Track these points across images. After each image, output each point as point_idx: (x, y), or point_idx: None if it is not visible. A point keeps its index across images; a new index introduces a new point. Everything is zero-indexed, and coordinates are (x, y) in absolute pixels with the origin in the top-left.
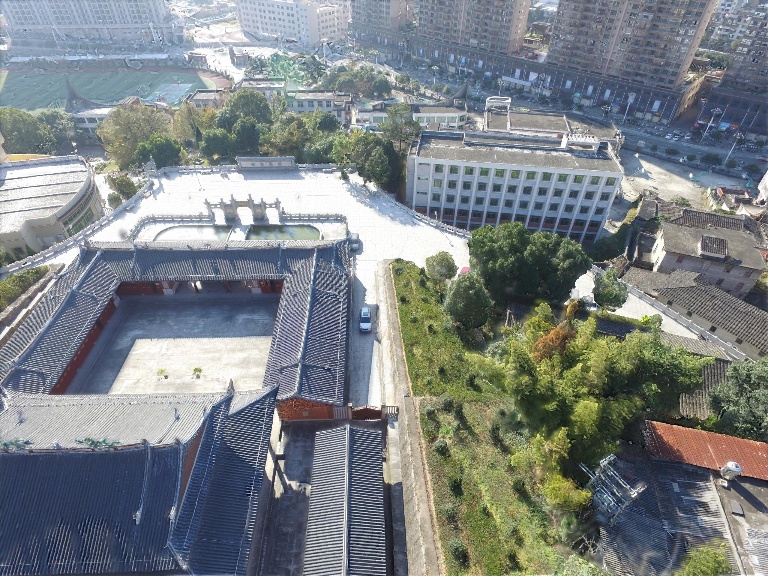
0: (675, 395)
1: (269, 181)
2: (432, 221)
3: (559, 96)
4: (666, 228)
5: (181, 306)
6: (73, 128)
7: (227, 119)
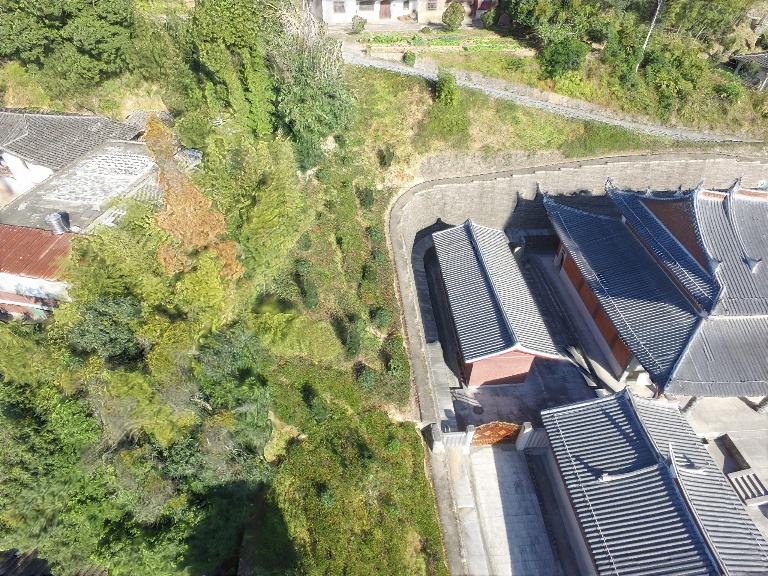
0: None
1: None
2: None
3: None
4: None
5: None
6: None
7: None
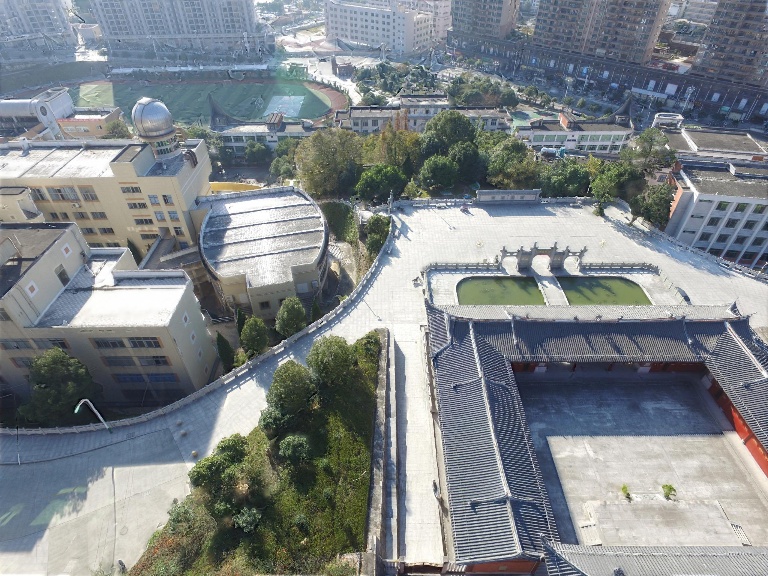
0: None
1: (519, 218)
2: (750, 271)
3: (702, 109)
4: None
5: (564, 389)
6: (222, 147)
7: (436, 144)
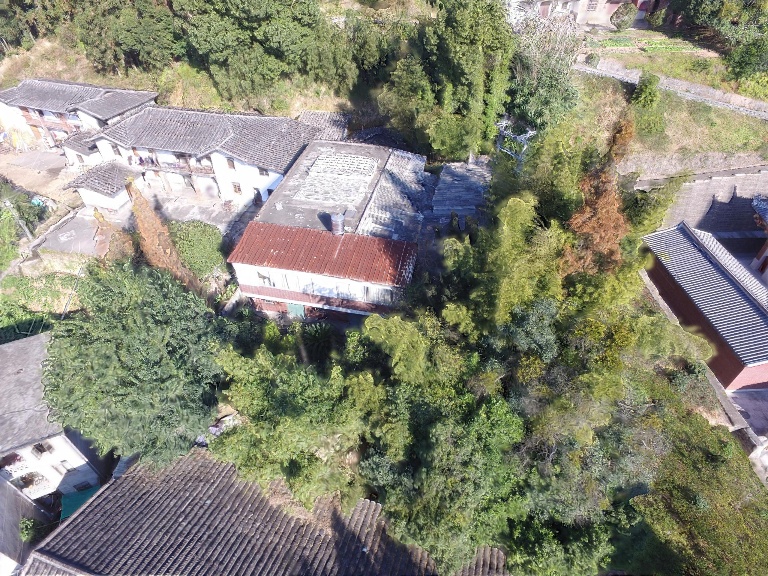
0: None
1: None
2: None
3: None
4: None
5: None
6: None
7: None
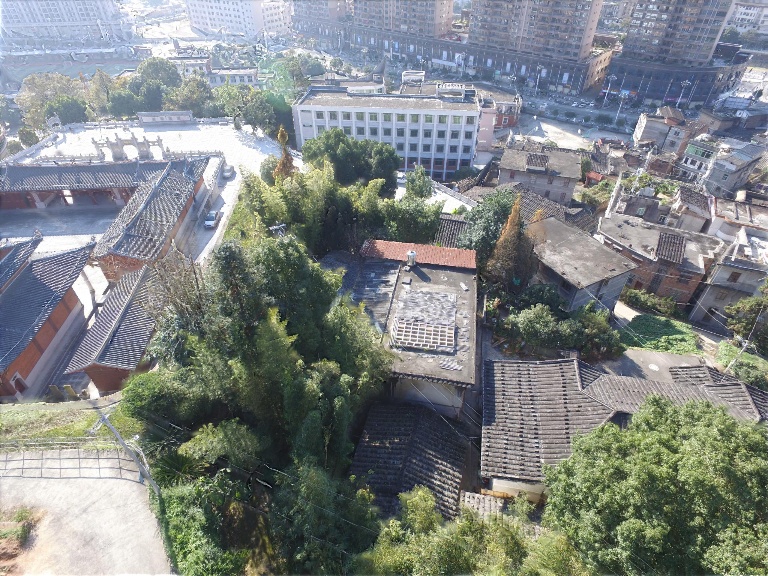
0: (421, 236)
1: (166, 132)
2: None
3: (482, 74)
4: (507, 153)
5: (50, 215)
6: (5, 108)
7: (137, 84)
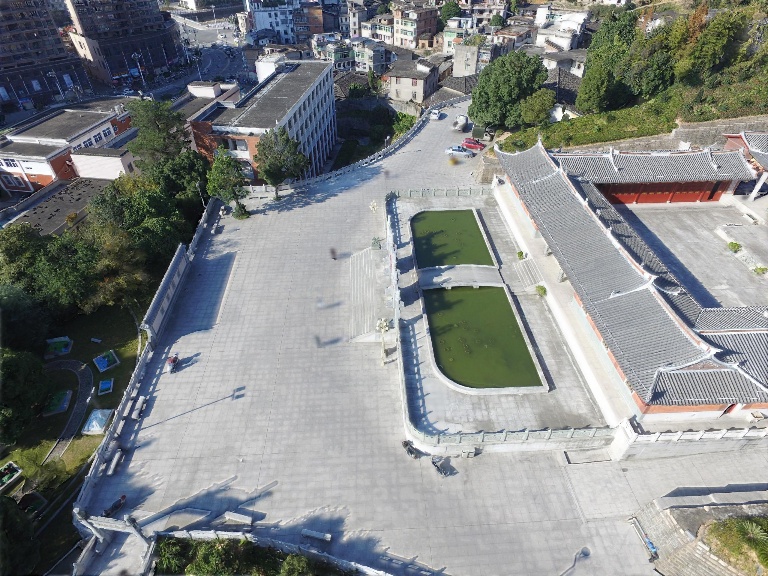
0: None
1: (231, 291)
2: None
3: None
4: (395, 75)
5: None
6: None
7: None
